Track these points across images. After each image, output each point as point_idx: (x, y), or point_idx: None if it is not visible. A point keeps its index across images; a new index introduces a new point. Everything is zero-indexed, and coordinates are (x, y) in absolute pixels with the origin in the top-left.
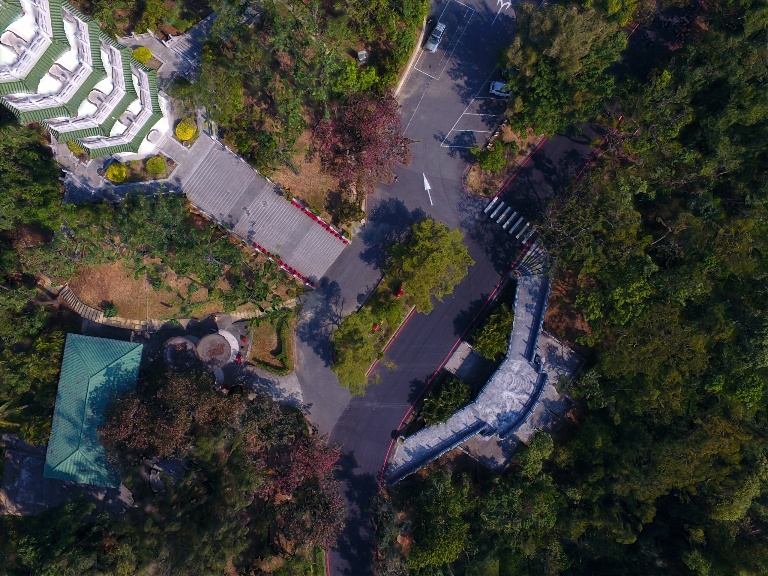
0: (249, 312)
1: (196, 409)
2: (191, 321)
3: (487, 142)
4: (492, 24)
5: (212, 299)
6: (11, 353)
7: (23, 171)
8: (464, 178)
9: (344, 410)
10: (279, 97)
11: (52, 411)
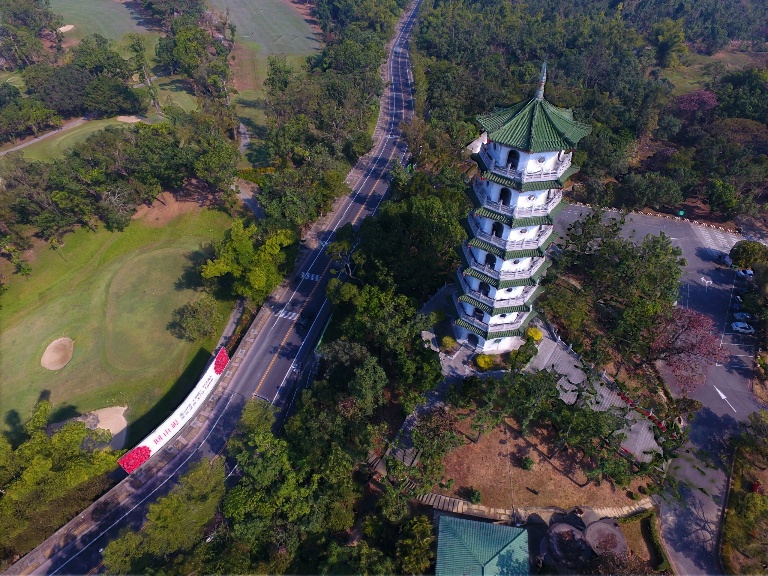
0: (608, 510)
1: None
2: (553, 516)
3: (754, 363)
4: (706, 292)
5: (572, 489)
6: (367, 545)
7: (412, 356)
8: (751, 390)
9: None
10: (635, 298)
11: None
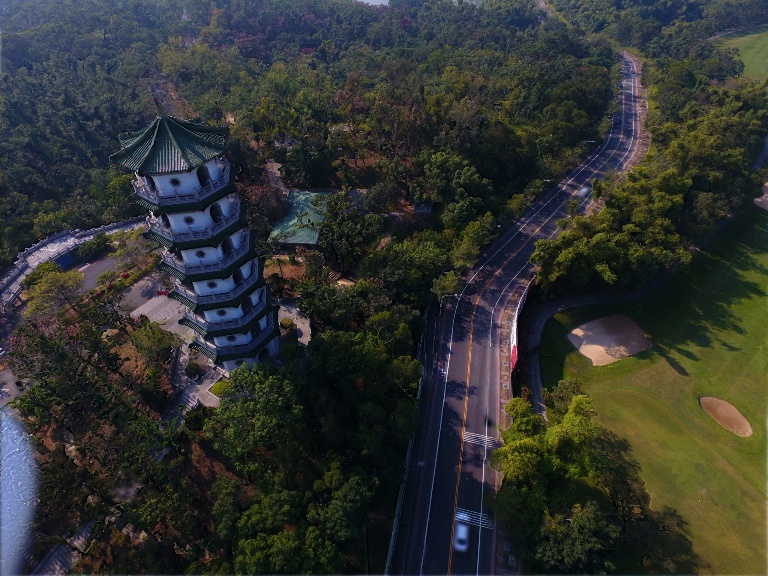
0: None
1: None
2: None
3: None
4: None
5: None
6: None
7: None
8: (5, 369)
9: None
10: None
11: None
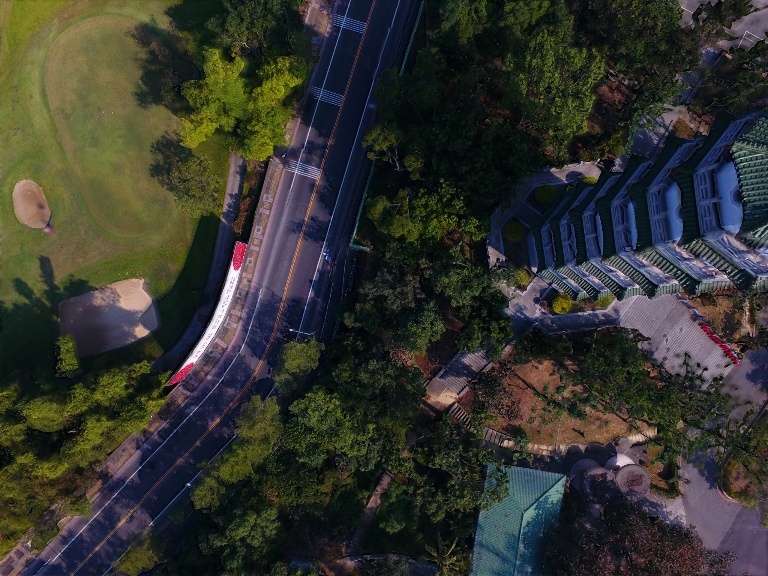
0: None
1: (666, 558)
2: (590, 444)
3: None
4: None
5: (616, 423)
6: None
7: (476, 304)
8: None
9: (726, 533)
10: None
11: (469, 541)
